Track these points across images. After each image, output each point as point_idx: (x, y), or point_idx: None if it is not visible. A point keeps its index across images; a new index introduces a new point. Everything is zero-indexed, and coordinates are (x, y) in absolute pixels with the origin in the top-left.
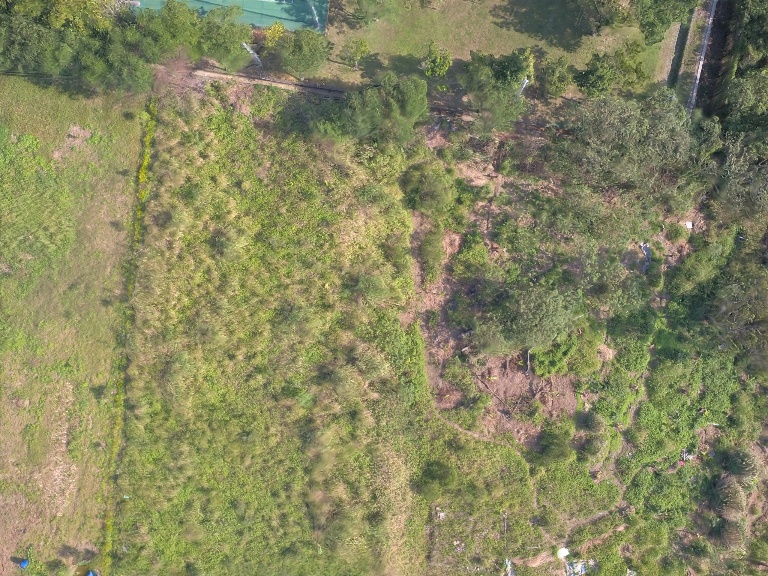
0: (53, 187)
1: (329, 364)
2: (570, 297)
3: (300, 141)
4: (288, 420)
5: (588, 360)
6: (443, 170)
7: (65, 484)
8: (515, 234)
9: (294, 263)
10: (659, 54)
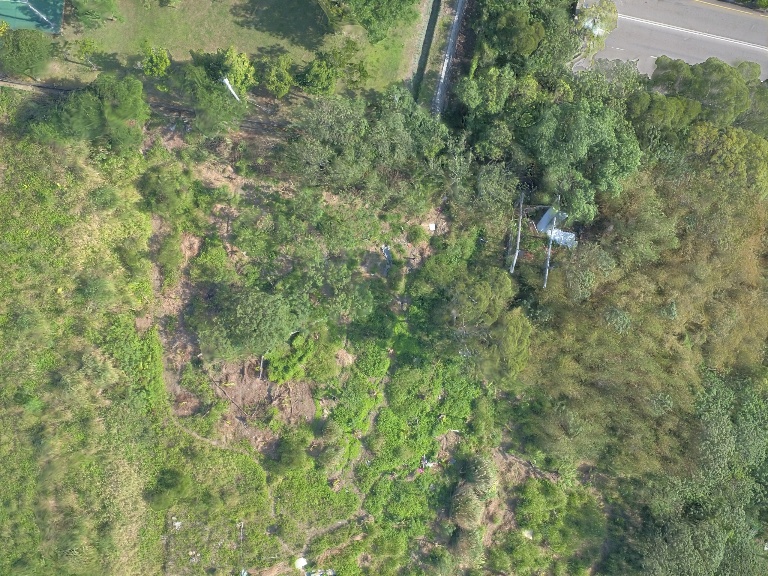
0: None
1: (61, 371)
2: (296, 301)
3: (34, 143)
4: (21, 428)
5: (324, 365)
6: (177, 172)
7: None
8: (253, 237)
9: (27, 268)
10: (402, 52)
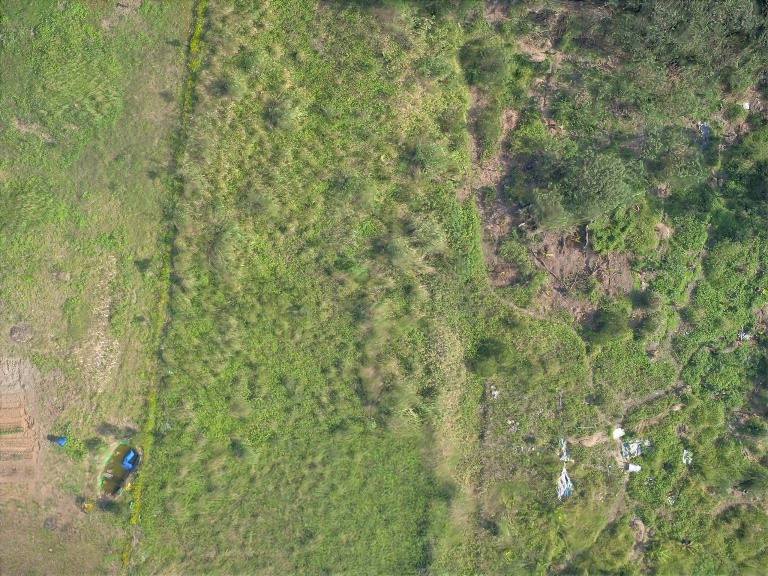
0: (100, 55)
1: (383, 237)
2: (631, 168)
3: (357, 12)
4: (340, 295)
5: (646, 237)
6: (502, 43)
7: (107, 360)
8: (573, 110)
9: (349, 135)
10: None
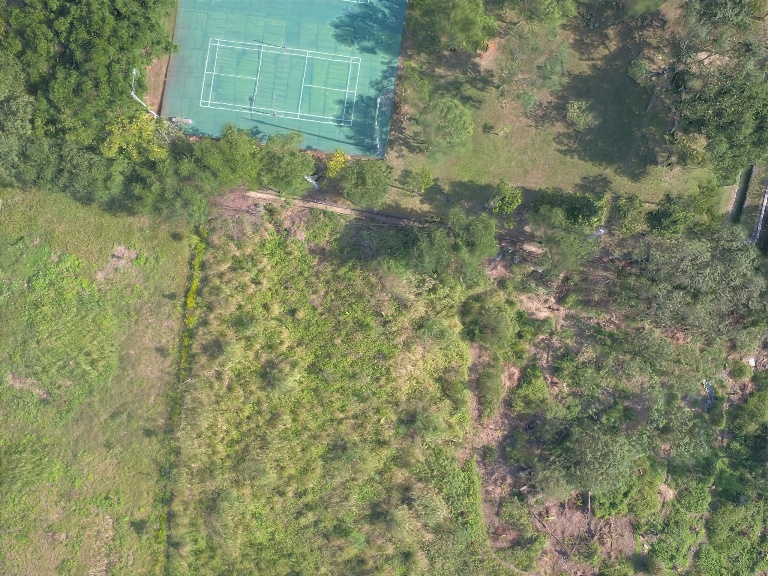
0: (95, 310)
1: (383, 502)
2: (635, 442)
3: (357, 270)
4: (339, 560)
5: (649, 502)
6: (504, 304)
7: None
8: (576, 370)
9: (348, 396)
10: (724, 187)
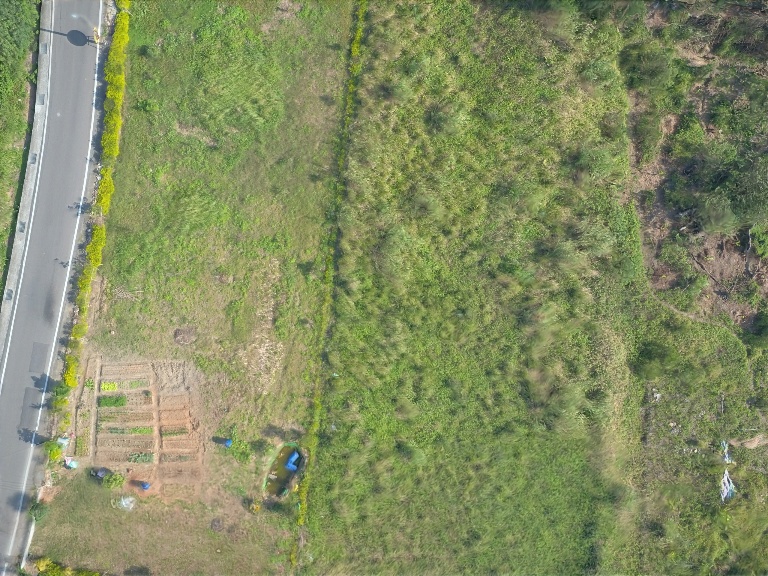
0: (261, 59)
1: (547, 241)
2: None
3: (518, 17)
4: (504, 298)
5: None
6: (663, 48)
7: (271, 362)
8: (732, 115)
9: (511, 139)
10: None
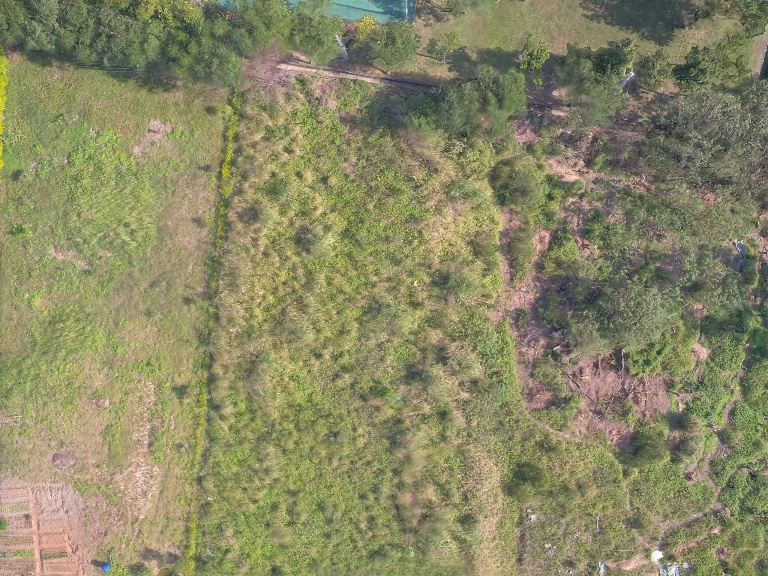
0: (134, 183)
1: (418, 363)
2: (668, 295)
3: (387, 136)
4: (376, 420)
5: (683, 359)
6: (534, 165)
7: (147, 486)
8: (607, 231)
9: (382, 260)
10: (753, 47)
